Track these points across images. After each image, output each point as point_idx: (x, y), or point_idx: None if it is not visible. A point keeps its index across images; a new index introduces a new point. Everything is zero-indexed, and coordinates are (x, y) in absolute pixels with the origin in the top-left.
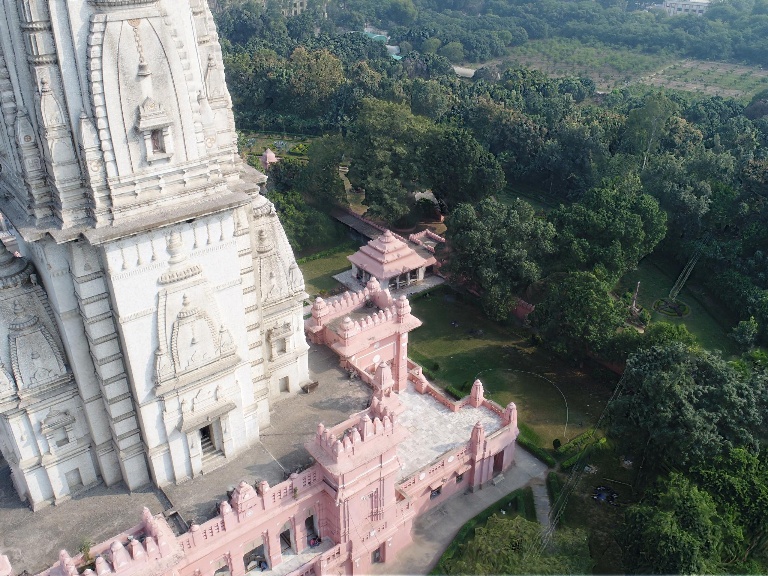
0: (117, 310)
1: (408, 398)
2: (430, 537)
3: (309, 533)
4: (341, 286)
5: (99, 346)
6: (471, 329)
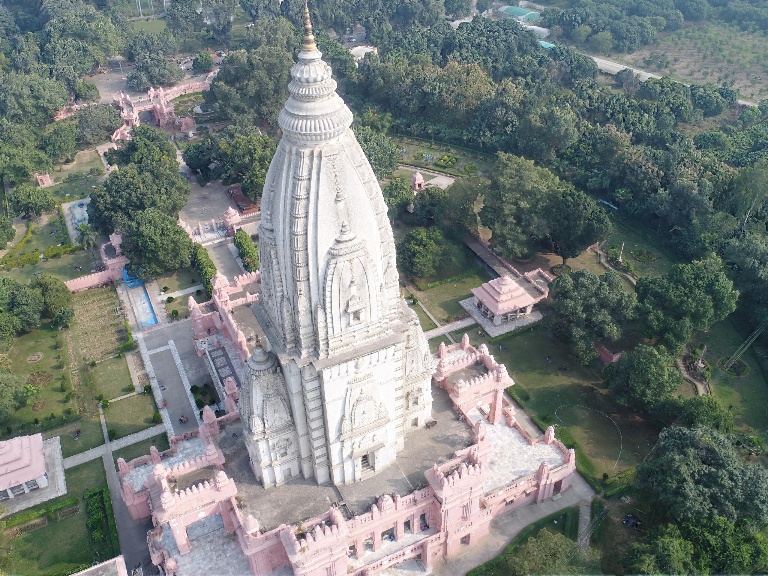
0: (325, 397)
1: (500, 429)
2: (502, 531)
3: (422, 522)
4: (464, 312)
5: (312, 412)
6: (561, 366)
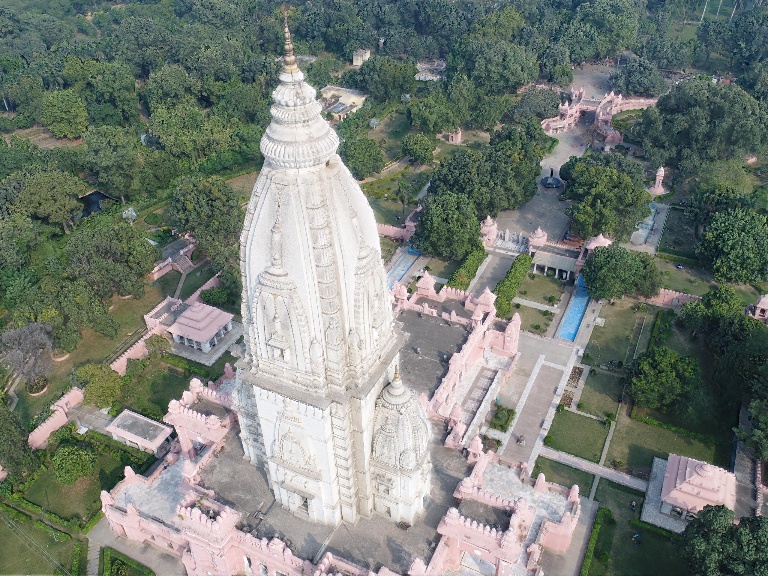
0: None
1: None
2: None
3: None
4: (647, 471)
5: None
6: None
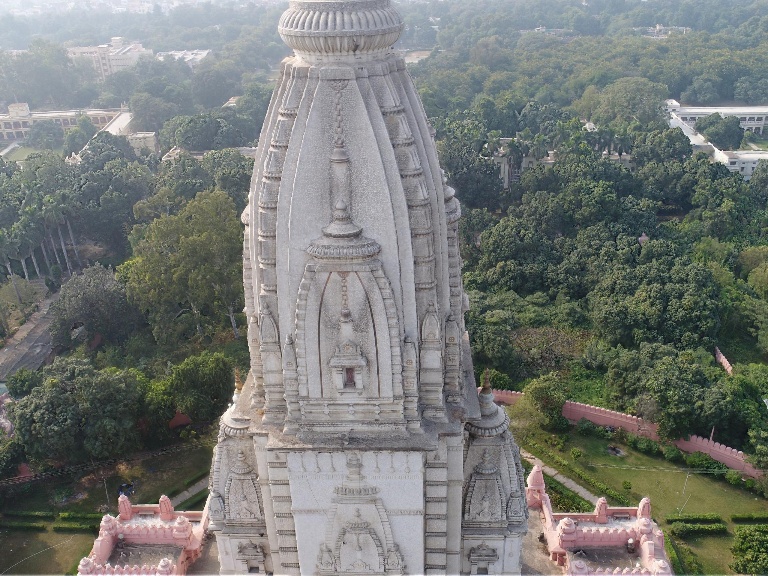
0: None
1: None
2: None
3: None
4: None
5: None
6: None
